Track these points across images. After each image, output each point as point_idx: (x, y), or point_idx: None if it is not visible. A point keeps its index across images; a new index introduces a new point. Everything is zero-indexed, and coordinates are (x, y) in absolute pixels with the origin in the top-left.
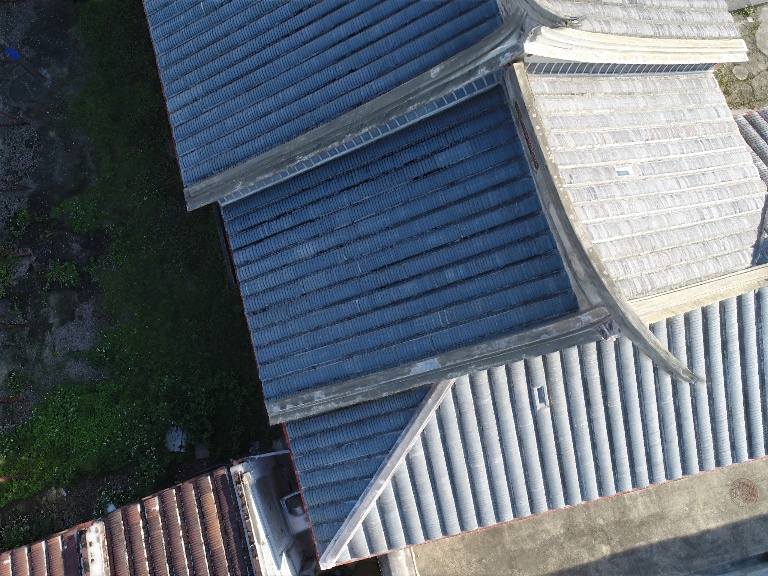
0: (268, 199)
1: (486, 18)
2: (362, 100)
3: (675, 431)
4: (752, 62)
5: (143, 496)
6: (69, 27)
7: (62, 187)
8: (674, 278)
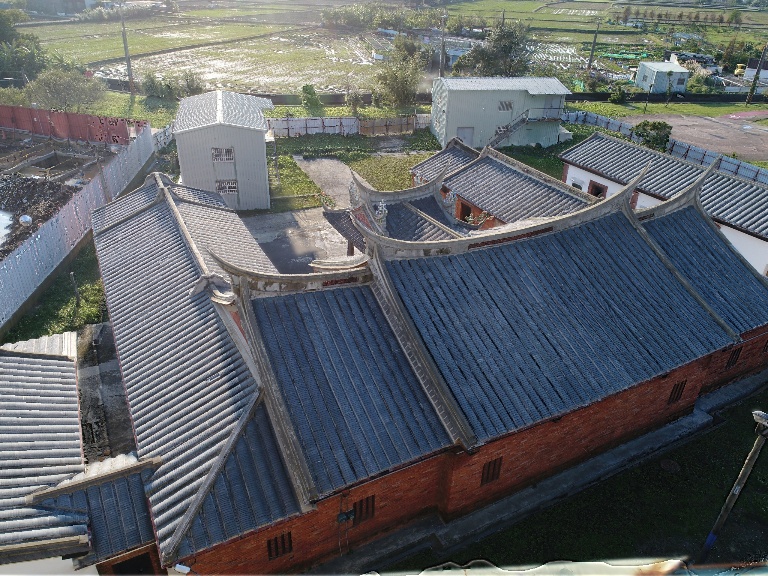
0: None
1: (618, 217)
2: None
3: None
4: None
5: None
6: (637, 563)
7: (763, 530)
8: None
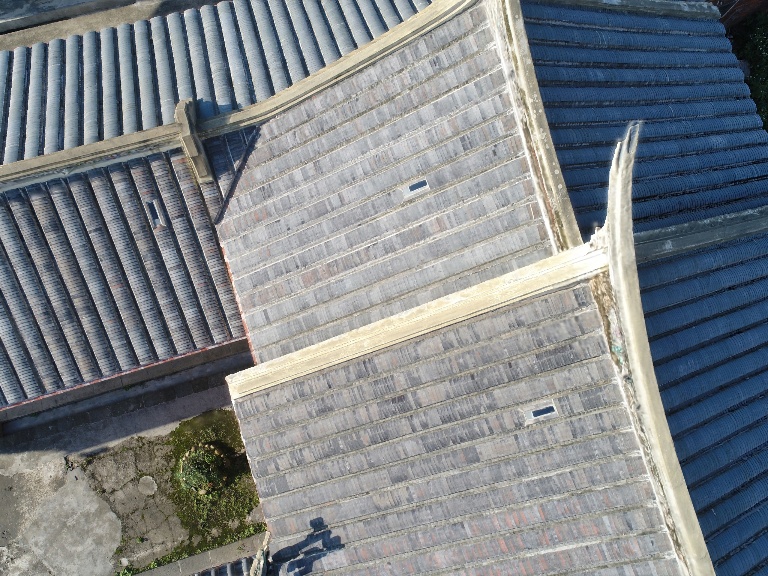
0: (759, 201)
1: None
2: (719, 250)
3: (327, 8)
4: (131, 501)
5: (765, 17)
6: None
7: None
8: (371, 74)
